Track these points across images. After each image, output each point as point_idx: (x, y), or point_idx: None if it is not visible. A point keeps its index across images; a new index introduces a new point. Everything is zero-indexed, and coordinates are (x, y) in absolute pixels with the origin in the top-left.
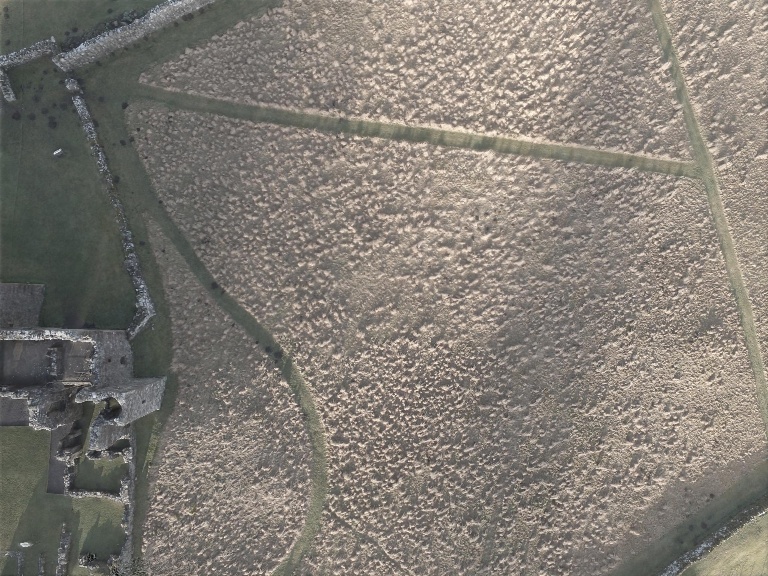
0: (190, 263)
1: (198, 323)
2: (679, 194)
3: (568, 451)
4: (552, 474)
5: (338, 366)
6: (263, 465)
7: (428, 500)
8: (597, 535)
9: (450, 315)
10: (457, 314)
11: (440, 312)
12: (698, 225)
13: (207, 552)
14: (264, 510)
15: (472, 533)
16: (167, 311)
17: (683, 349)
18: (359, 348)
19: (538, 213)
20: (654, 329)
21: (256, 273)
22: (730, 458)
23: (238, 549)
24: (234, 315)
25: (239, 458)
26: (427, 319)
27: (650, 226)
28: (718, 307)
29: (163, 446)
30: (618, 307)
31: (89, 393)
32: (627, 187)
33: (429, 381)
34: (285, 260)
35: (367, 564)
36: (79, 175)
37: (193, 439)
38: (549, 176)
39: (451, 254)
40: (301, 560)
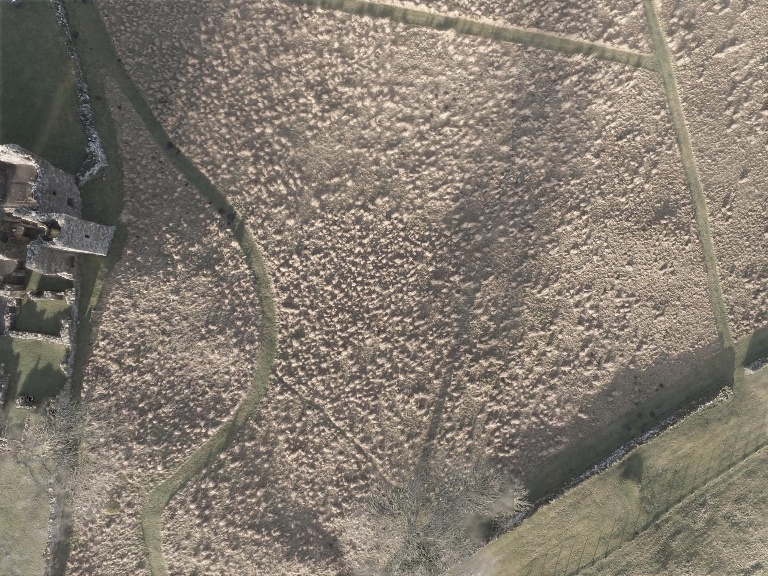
0: (146, 122)
1: (151, 179)
2: (637, 85)
3: (519, 330)
4: (502, 352)
5: (291, 232)
6: (210, 323)
7: (376, 370)
8: (545, 416)
9: (406, 190)
10: (413, 189)
11: (396, 186)
12: (655, 117)
13: (149, 405)
14: (210, 369)
15: (420, 406)
16: (120, 164)
17: (636, 237)
18: (313, 216)
19: (497, 95)
20: (608, 215)
21: (212, 135)
22: (680, 349)
23: (181, 405)
24: (188, 175)
25: (186, 314)
26: (383, 192)
27: (607, 114)
28: (672, 199)
29: (108, 292)
30: (573, 192)
31: (28, 210)
32: (586, 74)
33: (382, 253)
34: (242, 125)
35: (312, 430)
36: (37, 26)
37: (139, 289)
38: (509, 59)
39: (409, 130)
40: (245, 422)
